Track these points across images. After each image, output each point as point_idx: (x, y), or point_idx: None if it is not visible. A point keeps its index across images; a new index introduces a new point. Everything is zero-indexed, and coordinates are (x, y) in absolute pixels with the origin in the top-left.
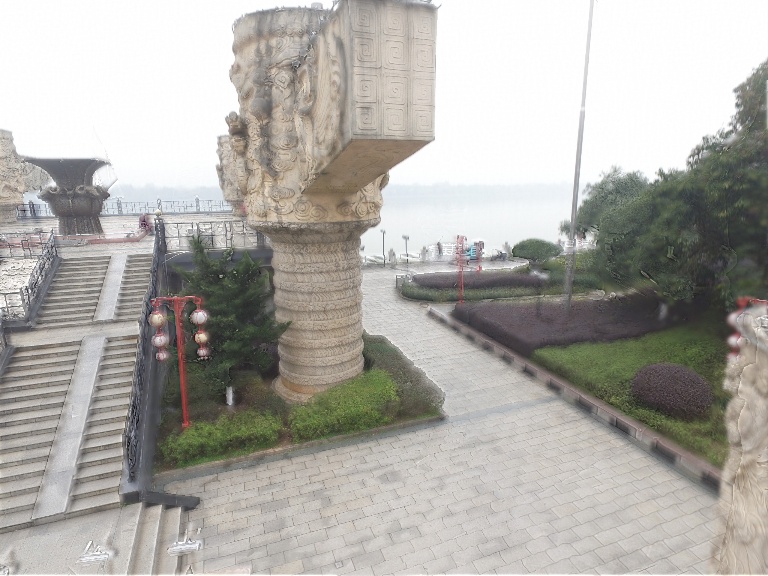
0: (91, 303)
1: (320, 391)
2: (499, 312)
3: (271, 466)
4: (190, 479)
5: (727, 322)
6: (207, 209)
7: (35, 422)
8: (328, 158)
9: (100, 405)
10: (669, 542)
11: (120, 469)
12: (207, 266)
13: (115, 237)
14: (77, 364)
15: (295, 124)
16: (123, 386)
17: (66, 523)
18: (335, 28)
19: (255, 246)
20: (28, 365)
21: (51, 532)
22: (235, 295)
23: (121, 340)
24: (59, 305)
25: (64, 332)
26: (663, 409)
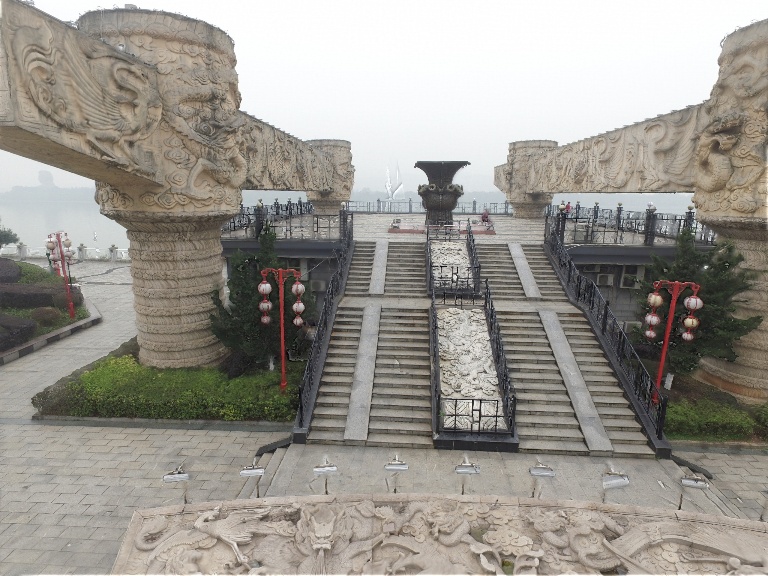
0: (515, 282)
1: (767, 396)
2: None
3: (760, 459)
4: (678, 451)
5: None
6: (482, 211)
7: (540, 373)
8: None
9: (586, 368)
10: None
11: (638, 426)
12: (695, 256)
13: (476, 229)
14: (547, 331)
15: None
16: (593, 356)
17: (617, 460)
18: None
19: (644, 244)
20: (508, 326)
21: (612, 464)
22: (721, 286)
23: (567, 316)
24: (492, 281)
25: (511, 303)
26: None
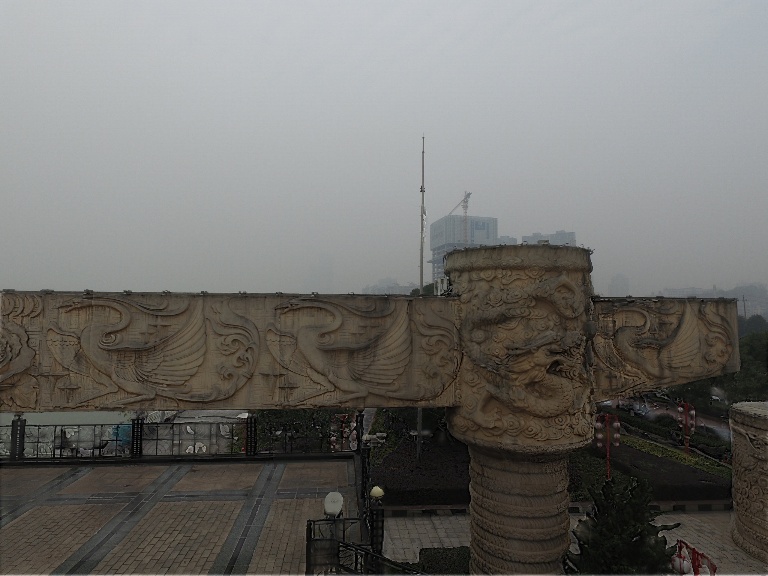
0: None
1: None
2: (401, 480)
3: None
4: None
5: None
6: None
7: None
8: (692, 378)
9: None
10: (680, 538)
11: None
12: None
13: None
14: None
15: (596, 345)
16: None
17: None
18: (711, 307)
19: None
20: None
21: None
22: None
23: None
24: None
25: None
26: (576, 489)
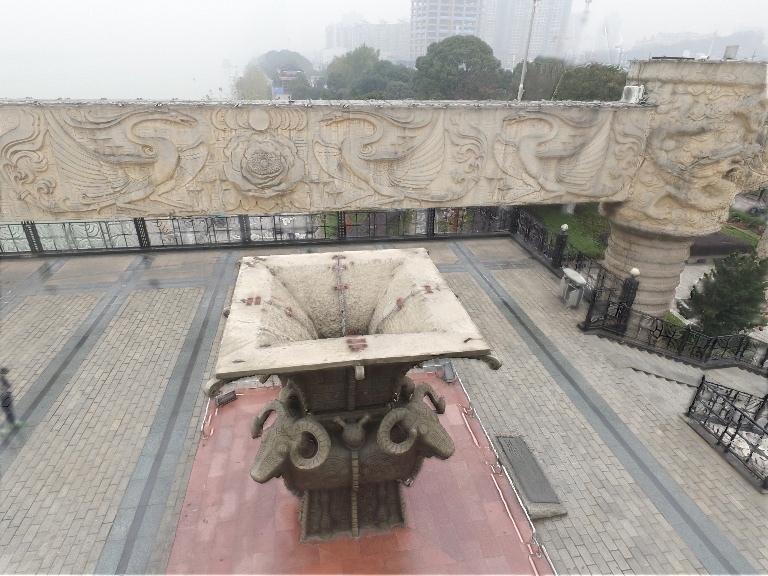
0: None
1: None
2: None
3: None
4: None
5: (552, 205)
6: None
7: None
8: None
9: None
10: None
11: None
12: None
13: (448, 398)
14: None
15: None
16: None
17: None
18: None
19: None
20: None
21: None
22: None
23: None
24: None
25: None
26: None
